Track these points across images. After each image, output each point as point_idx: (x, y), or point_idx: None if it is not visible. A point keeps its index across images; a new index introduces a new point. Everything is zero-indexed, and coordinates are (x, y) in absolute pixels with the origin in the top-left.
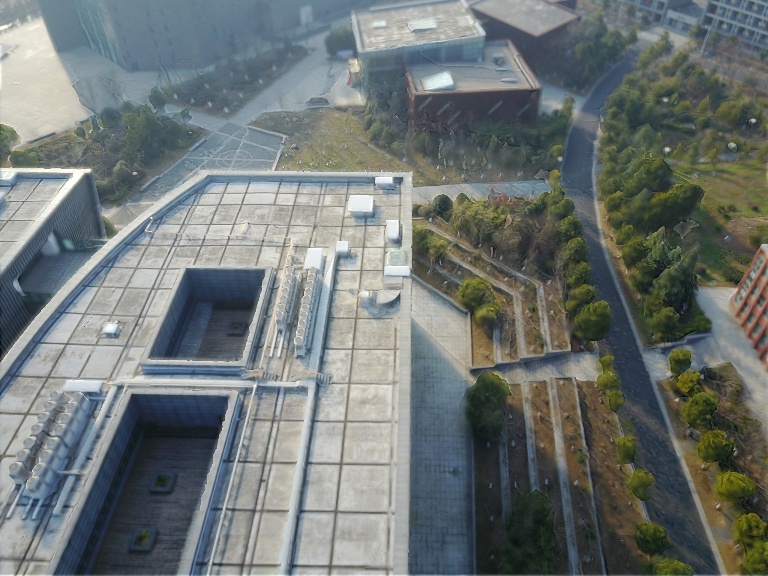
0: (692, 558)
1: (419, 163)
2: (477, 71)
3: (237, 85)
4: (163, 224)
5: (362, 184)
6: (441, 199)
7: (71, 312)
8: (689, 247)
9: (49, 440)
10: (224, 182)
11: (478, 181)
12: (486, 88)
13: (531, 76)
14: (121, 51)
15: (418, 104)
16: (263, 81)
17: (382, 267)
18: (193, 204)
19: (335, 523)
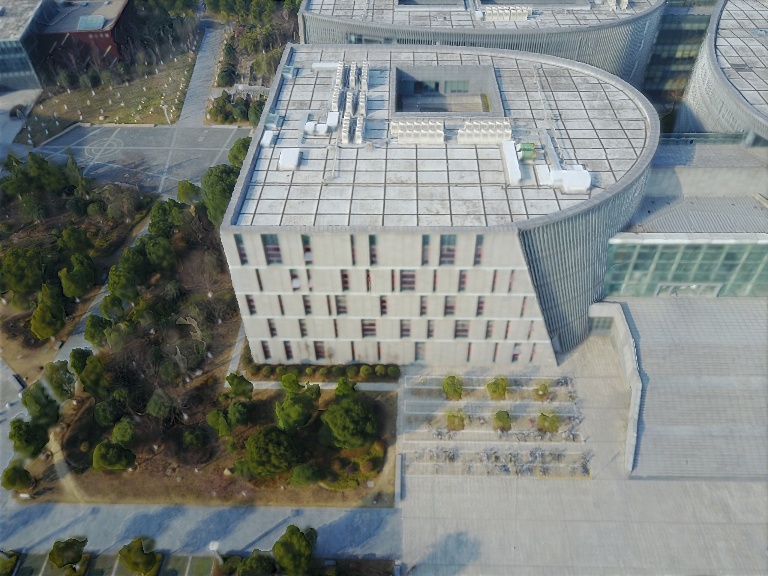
0: None
1: (163, 68)
2: (80, 11)
3: None
4: None
5: None
6: None
7: None
8: None
9: None
10: None
11: (197, 51)
12: (121, 6)
13: None
14: None
15: (114, 37)
16: None
17: None
18: None
19: None
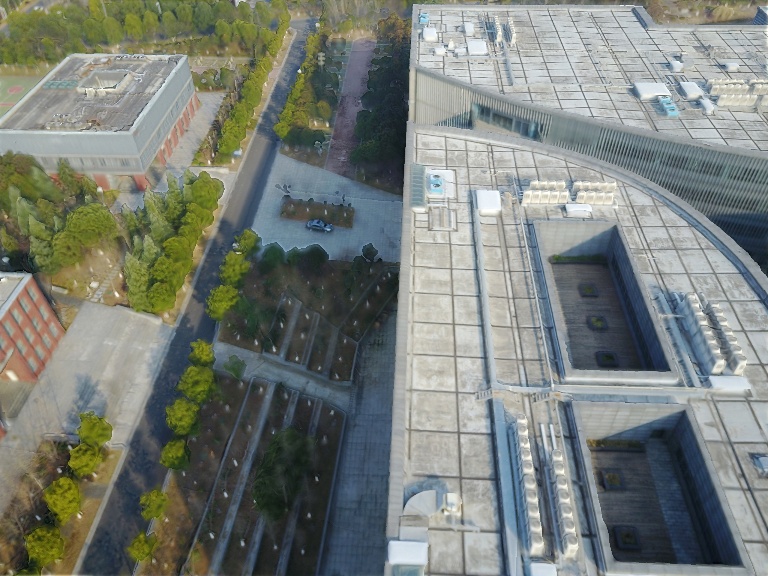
0: (141, 469)
1: None
2: None
3: None
4: None
5: None
6: None
7: None
8: None
9: None
10: None
11: None
12: None
13: None
14: None
15: None
16: None
17: None
18: None
19: (452, 289)
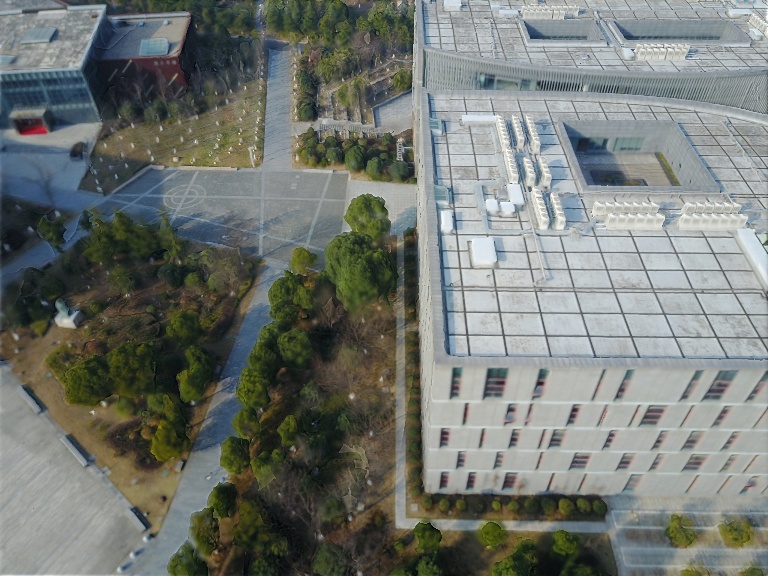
0: None
1: (232, 97)
2: (138, 33)
3: None
4: None
5: (425, 7)
6: (310, 76)
7: None
8: (366, 16)
9: (667, 44)
10: None
11: (266, 77)
12: (184, 27)
13: (168, 12)
14: None
15: (181, 63)
16: None
17: (506, 1)
18: None
19: (653, 6)
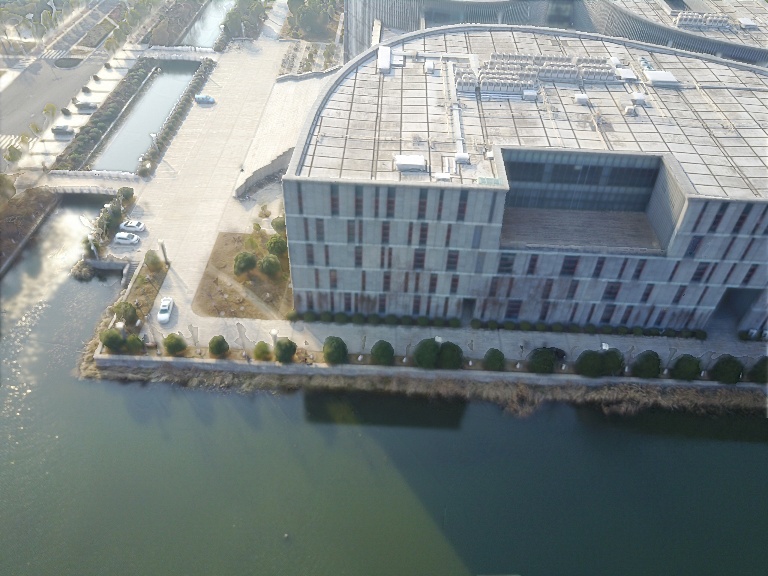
0: None
1: None
2: None
3: None
4: None
5: None
6: None
7: None
8: None
9: None
10: None
11: None
12: None
13: None
14: None
15: None
16: None
17: None
18: None
19: (739, 2)
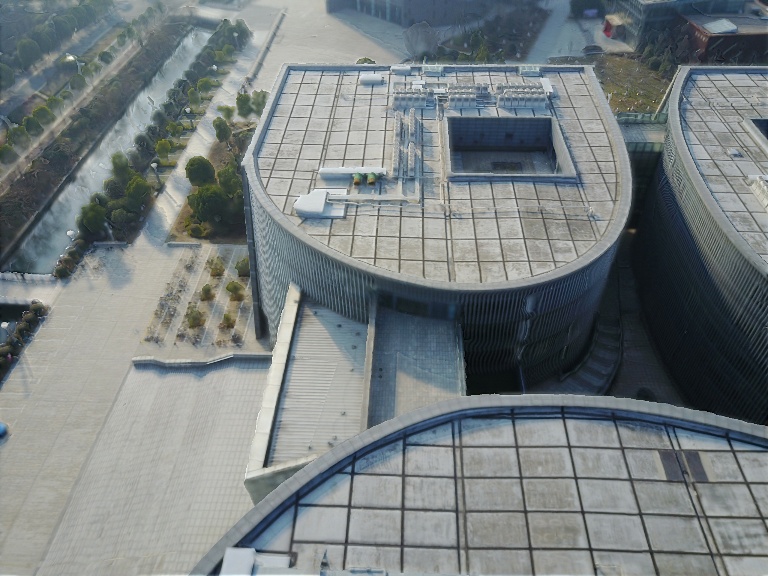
0: None
1: None
2: (745, 20)
3: (512, 37)
4: (689, 98)
5: None
6: None
7: (692, 144)
8: None
9: None
10: (701, 74)
11: None
12: None
13: None
14: (404, 9)
15: (711, 44)
16: (531, 34)
17: None
18: (695, 87)
19: None
